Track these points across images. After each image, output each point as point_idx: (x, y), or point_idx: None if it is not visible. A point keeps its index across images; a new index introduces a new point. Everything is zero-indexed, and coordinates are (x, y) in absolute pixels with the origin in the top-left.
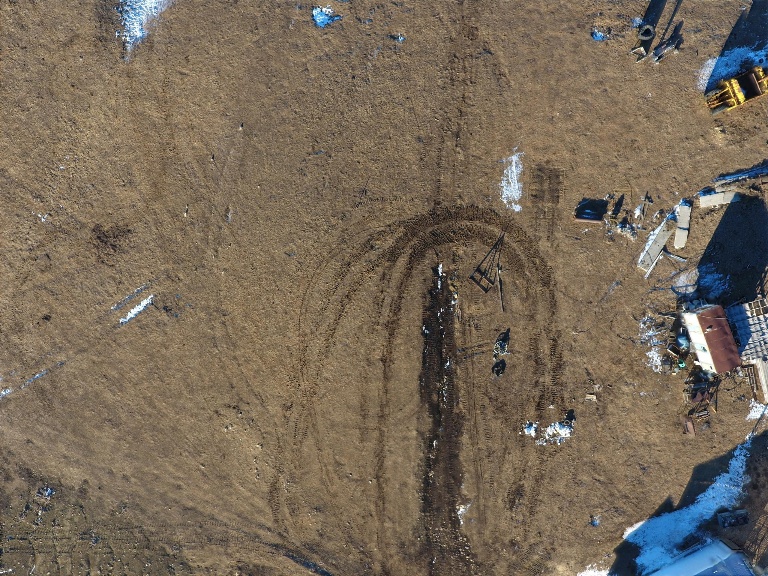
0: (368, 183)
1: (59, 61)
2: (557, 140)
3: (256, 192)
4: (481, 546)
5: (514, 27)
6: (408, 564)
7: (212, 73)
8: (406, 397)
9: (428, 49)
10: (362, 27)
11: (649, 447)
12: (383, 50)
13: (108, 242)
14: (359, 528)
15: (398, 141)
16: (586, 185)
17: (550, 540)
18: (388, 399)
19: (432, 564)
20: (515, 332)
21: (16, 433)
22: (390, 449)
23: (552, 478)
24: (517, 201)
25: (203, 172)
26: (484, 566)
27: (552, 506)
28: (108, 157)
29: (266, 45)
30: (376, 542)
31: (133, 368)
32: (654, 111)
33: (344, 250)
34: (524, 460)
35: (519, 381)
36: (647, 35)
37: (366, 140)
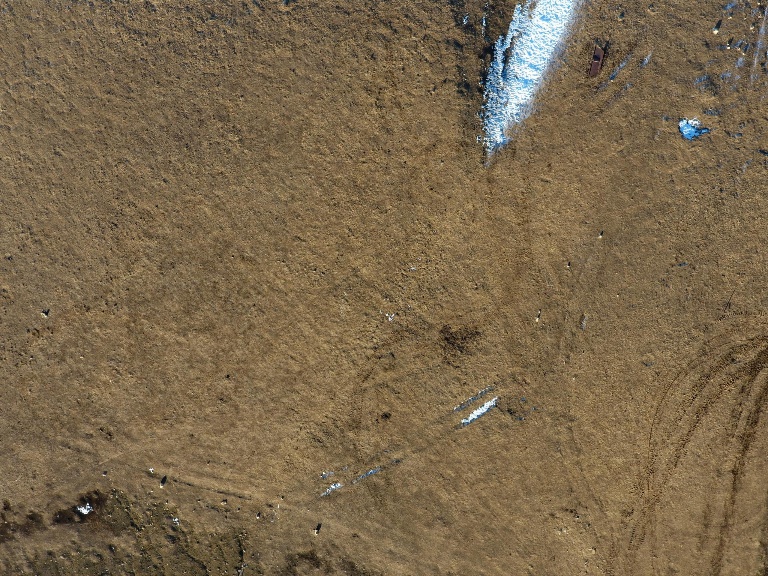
0: (732, 296)
1: (420, 165)
2: None
3: (614, 301)
4: None
5: None
6: None
7: (574, 181)
8: (753, 509)
9: None
10: (731, 141)
11: None
12: (753, 165)
13: (455, 343)
14: None
15: (765, 256)
16: None
17: None
18: (734, 510)
19: None
20: None
21: (343, 527)
22: (729, 558)
23: None
24: None
25: (558, 278)
26: None
27: None
28: (462, 260)
29: (630, 155)
30: None
31: (471, 468)
32: None
33: (704, 362)
34: None
35: None
36: None
37: (732, 254)
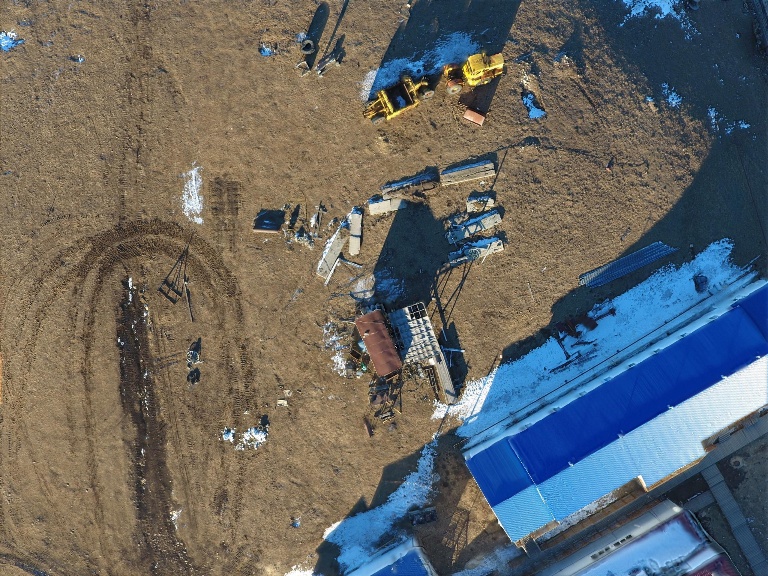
0: (55, 201)
1: None
2: (232, 154)
3: None
4: (196, 550)
5: (186, 45)
6: (132, 570)
7: None
8: (109, 408)
9: (106, 69)
10: (44, 50)
11: (340, 449)
12: (64, 71)
13: None
14: (82, 536)
15: (81, 159)
16: (263, 196)
17: (256, 542)
18: (92, 410)
19: (154, 569)
20: (206, 341)
21: None
22: (101, 458)
23: (252, 482)
24: (199, 214)
25: None
26: (202, 570)
27: (255, 509)
28: None
29: None
30: (100, 549)
31: None
32: (321, 123)
33: (36, 267)
34: (226, 465)
35: (214, 389)
36: (308, 49)
37: (51, 159)
